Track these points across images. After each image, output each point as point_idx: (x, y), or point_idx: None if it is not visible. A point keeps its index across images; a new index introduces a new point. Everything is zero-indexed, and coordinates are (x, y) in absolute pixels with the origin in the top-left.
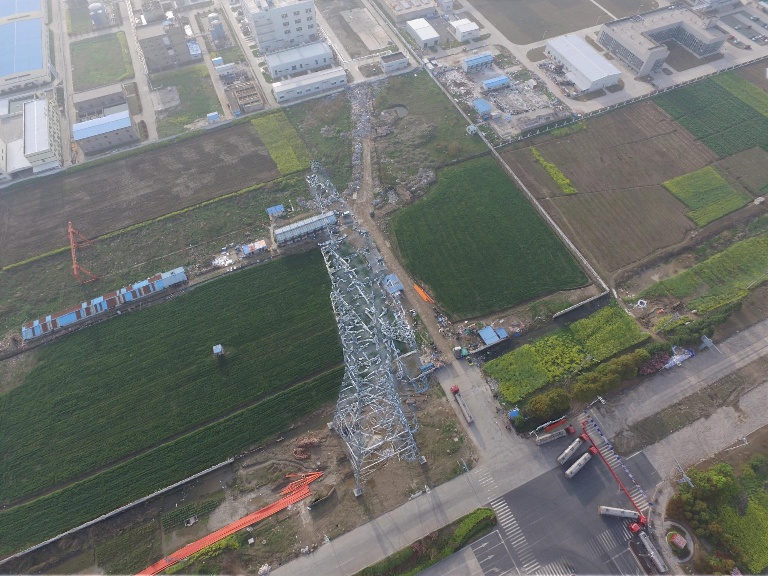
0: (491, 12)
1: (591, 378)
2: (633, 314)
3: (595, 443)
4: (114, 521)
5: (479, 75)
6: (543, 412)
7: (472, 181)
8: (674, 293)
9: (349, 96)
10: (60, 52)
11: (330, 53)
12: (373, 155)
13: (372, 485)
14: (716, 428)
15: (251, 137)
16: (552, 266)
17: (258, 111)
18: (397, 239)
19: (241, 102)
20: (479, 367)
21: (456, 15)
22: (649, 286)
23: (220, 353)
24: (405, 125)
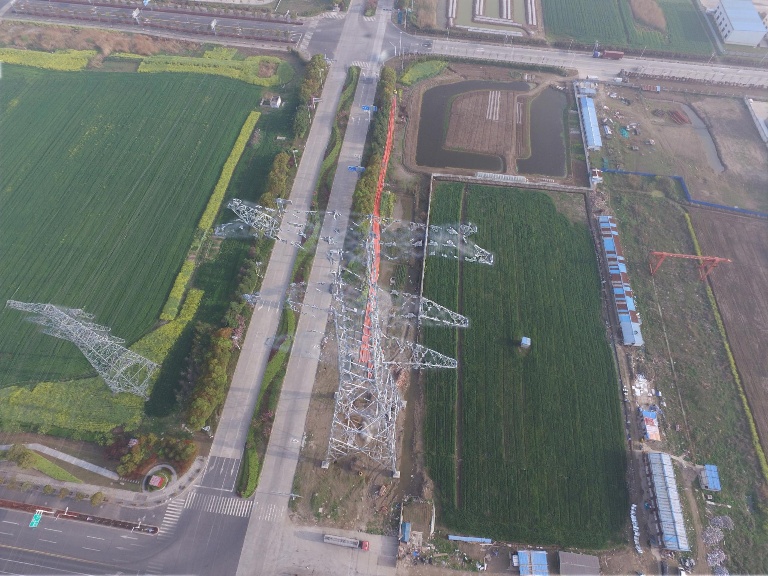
0: None
1: None
2: None
3: None
4: None
5: None
6: None
7: None
8: None
9: None
10: None
11: None
12: None
13: None
14: None
15: None
16: None
17: None
18: None
19: None
20: None
21: None
22: None
23: None
24: None
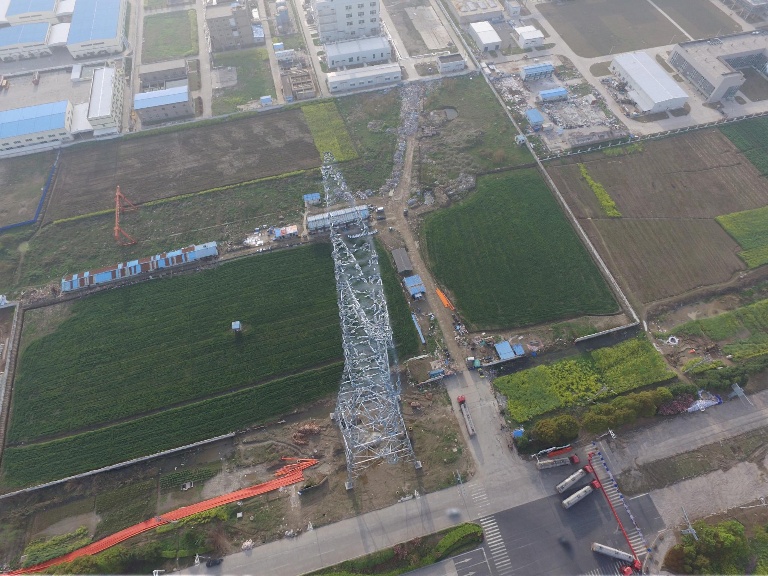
0: (559, 21)
1: (605, 410)
2: (662, 350)
3: (599, 477)
4: (117, 473)
5: (536, 85)
6: (548, 436)
7: (512, 192)
8: (710, 334)
9: (401, 93)
10: (134, 24)
11: (388, 48)
12: (416, 154)
13: (364, 481)
14: (734, 483)
15: (299, 123)
16: (582, 289)
17: (310, 99)
18: (427, 241)
19: (295, 88)
20: (490, 381)
21: (522, 21)
22: (684, 323)
23: (238, 329)
24: (452, 128)
